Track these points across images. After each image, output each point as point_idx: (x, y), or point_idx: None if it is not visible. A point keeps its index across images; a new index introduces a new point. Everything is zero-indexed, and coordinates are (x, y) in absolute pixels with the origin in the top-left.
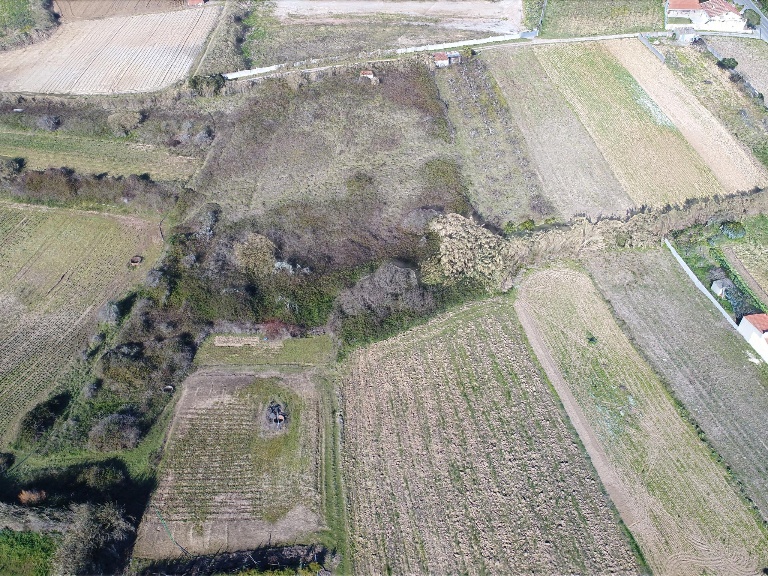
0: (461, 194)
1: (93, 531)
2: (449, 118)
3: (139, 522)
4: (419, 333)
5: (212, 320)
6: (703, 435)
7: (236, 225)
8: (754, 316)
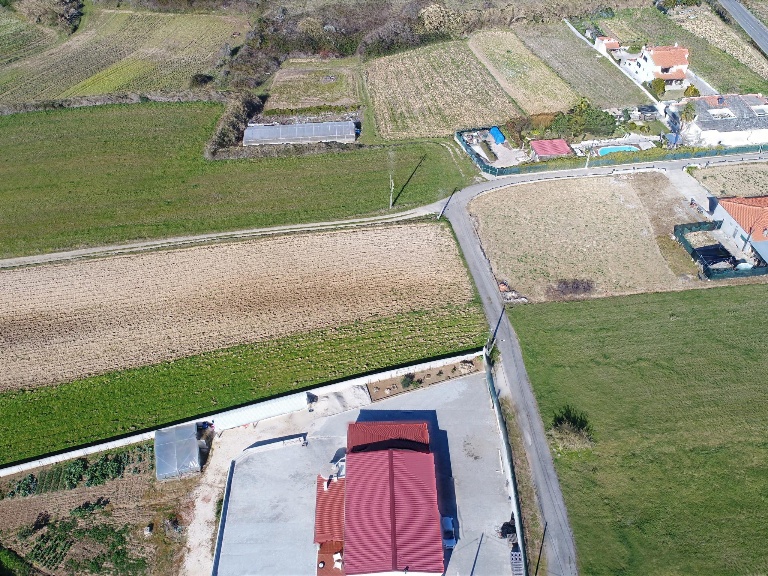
0: None
1: (245, 94)
2: None
3: (264, 103)
4: (410, 53)
5: (288, 53)
6: (560, 75)
7: (297, 15)
8: (602, 37)
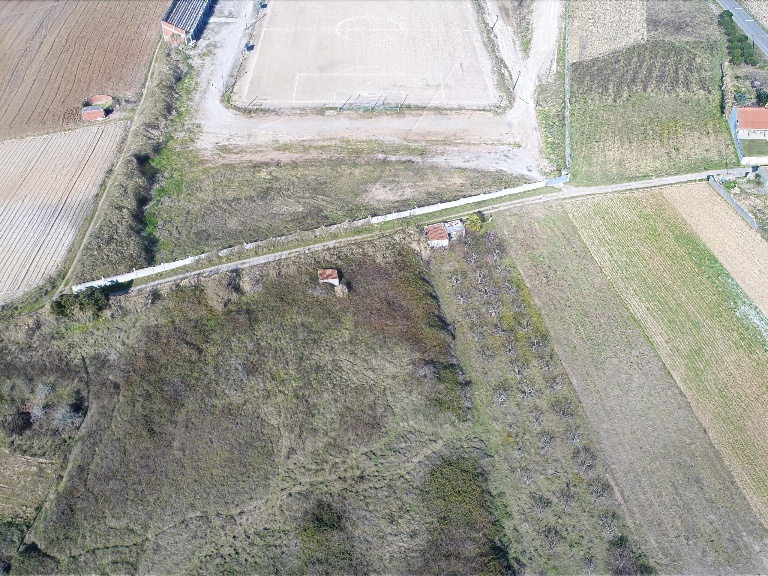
0: (493, 547)
1: None
2: (458, 359)
3: None
4: None
5: None
6: None
7: None
8: None
